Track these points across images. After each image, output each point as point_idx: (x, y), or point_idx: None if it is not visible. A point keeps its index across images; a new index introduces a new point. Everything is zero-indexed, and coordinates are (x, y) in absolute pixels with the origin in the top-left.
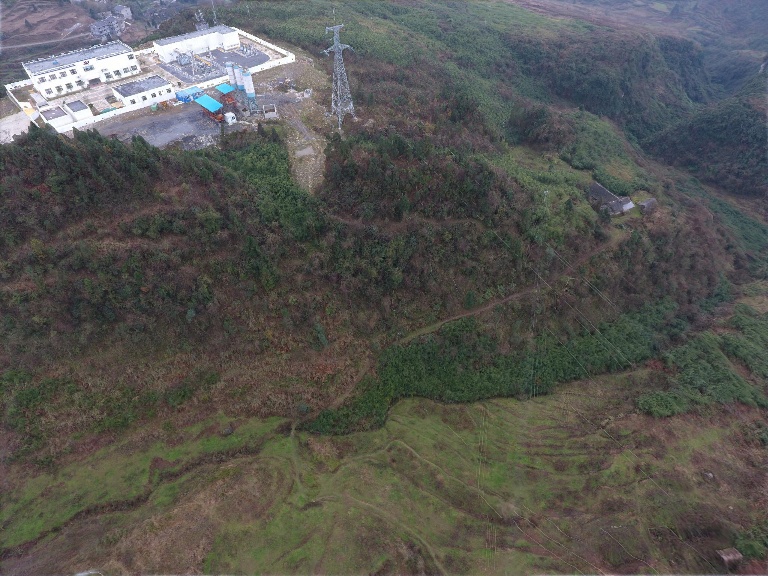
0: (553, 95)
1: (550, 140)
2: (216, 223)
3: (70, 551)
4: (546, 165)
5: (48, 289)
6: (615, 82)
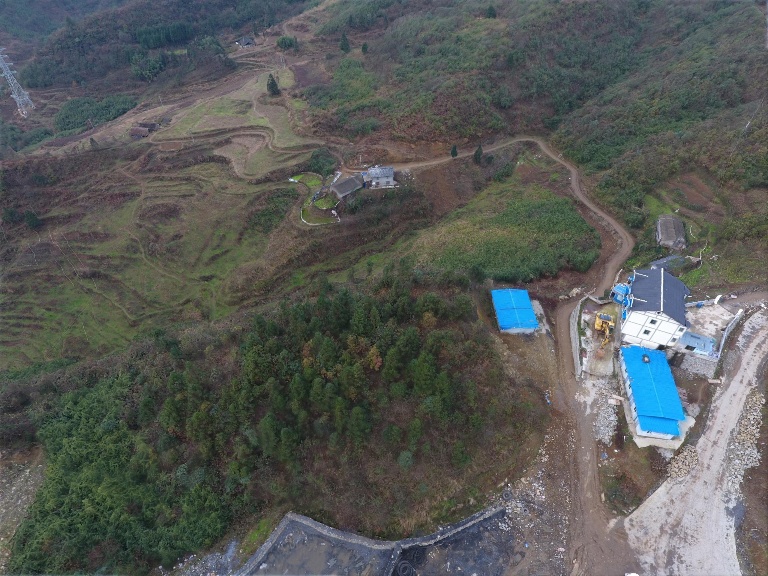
0: None
1: None
2: None
3: (342, 249)
4: None
5: None
6: None
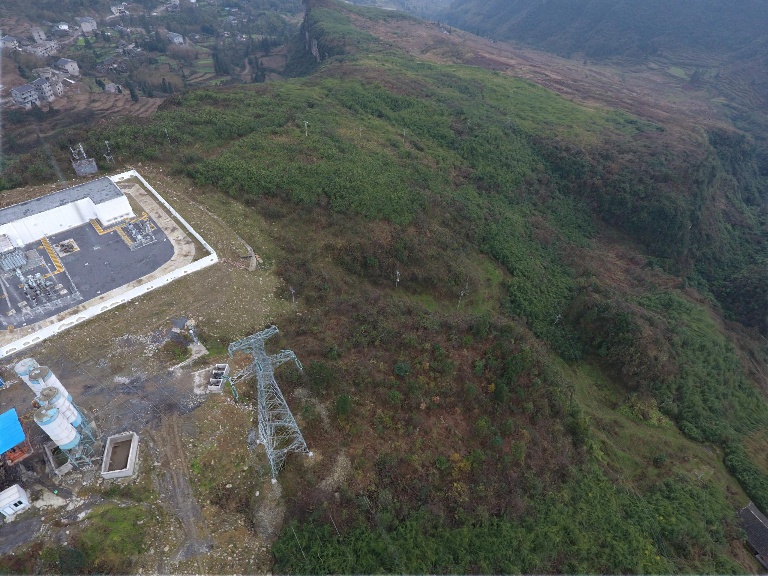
0: (598, 221)
1: (641, 374)
2: None
3: None
4: (640, 428)
5: None
6: (684, 214)
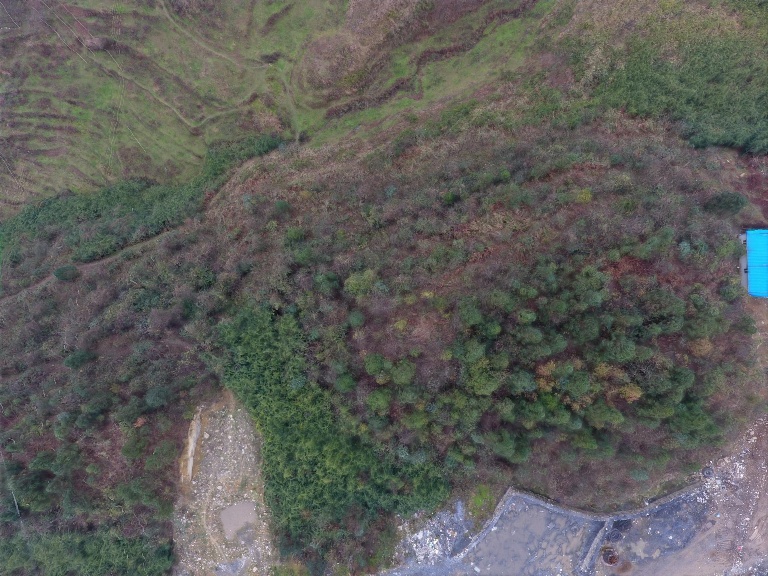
0: None
1: None
2: None
3: (461, 11)
4: None
5: (552, 164)
6: None
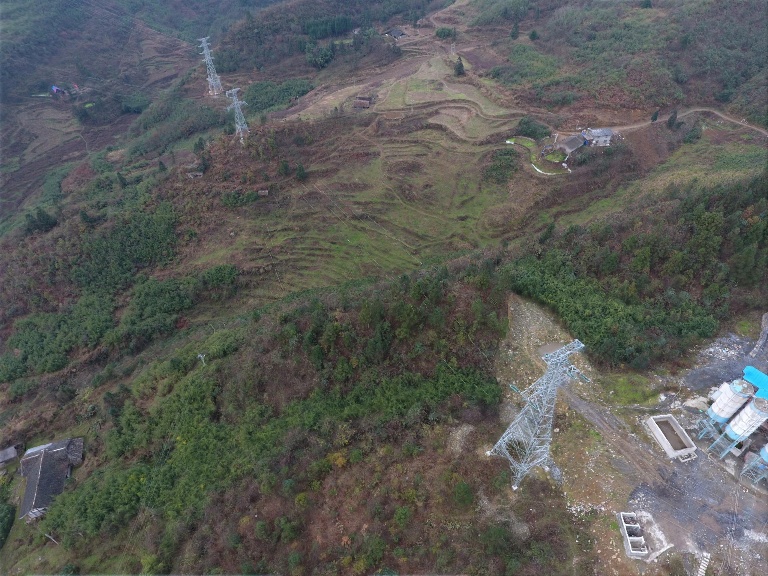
0: None
1: None
2: None
3: (575, 195)
4: None
5: None
6: None
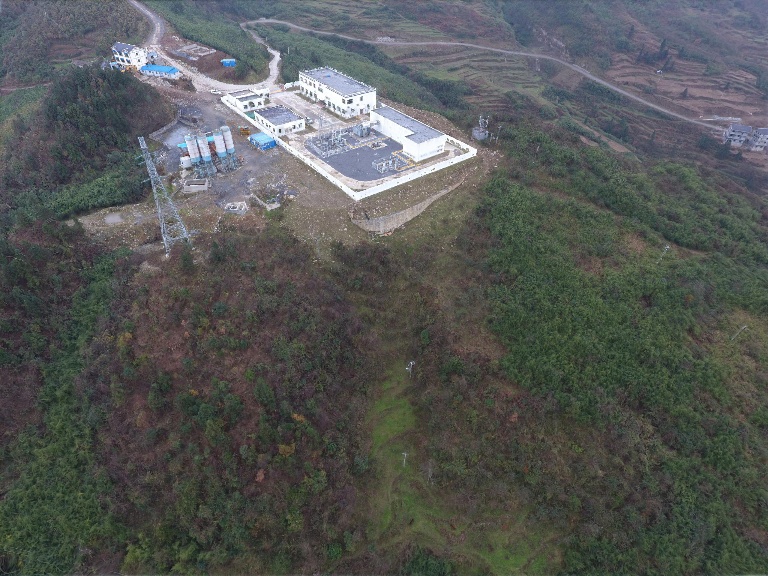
0: None
1: None
2: (14, 172)
3: None
4: None
5: None
6: None
